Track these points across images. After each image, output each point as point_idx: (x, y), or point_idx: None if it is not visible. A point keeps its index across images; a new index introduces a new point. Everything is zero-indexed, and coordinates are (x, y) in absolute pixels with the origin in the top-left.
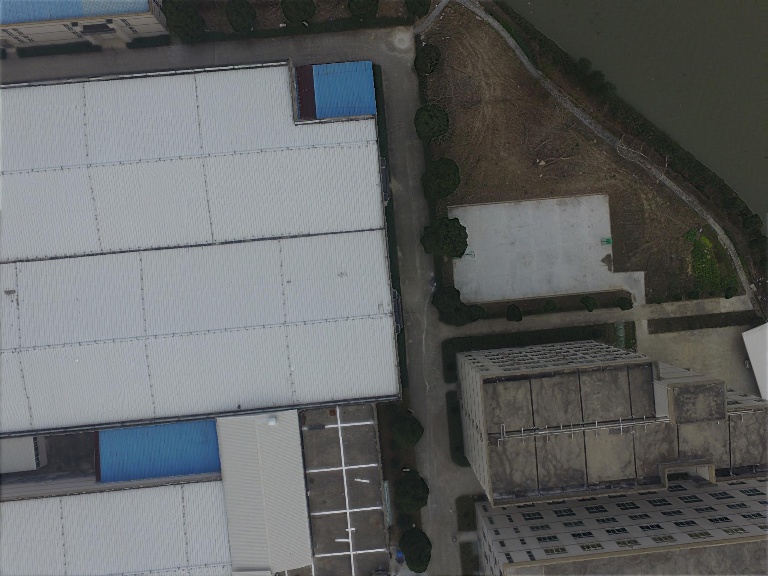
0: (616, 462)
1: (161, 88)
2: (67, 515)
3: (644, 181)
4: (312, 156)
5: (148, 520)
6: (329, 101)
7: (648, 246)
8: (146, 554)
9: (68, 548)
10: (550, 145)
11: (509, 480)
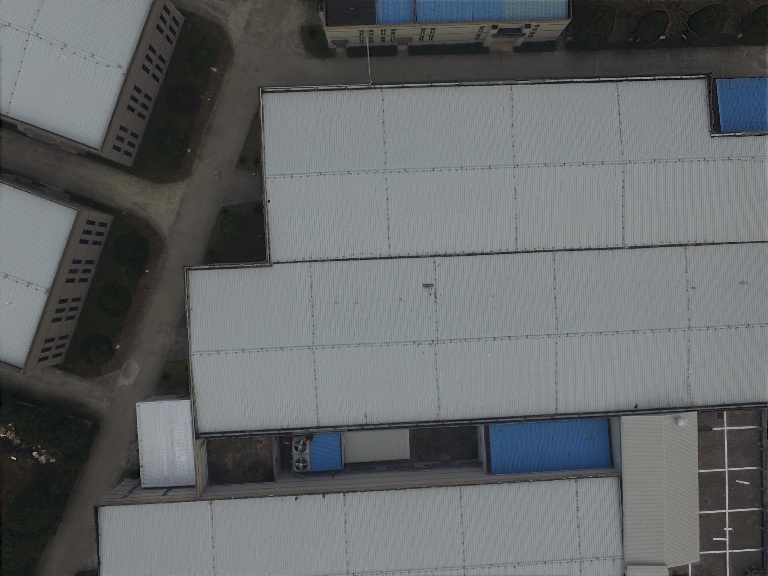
0: None
1: (585, 94)
2: (466, 504)
3: None
4: (726, 168)
5: (543, 512)
6: (732, 115)
7: None
8: (541, 545)
9: (467, 536)
10: None
11: None
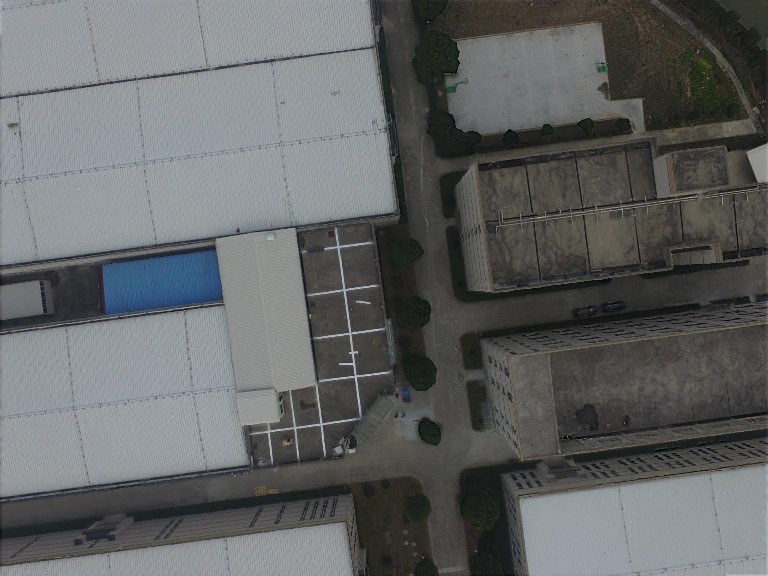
0: (619, 247)
1: None
2: (73, 344)
3: (637, 5)
4: None
5: (152, 346)
6: None
7: (644, 69)
8: (151, 380)
9: (75, 376)
10: None
11: (509, 269)
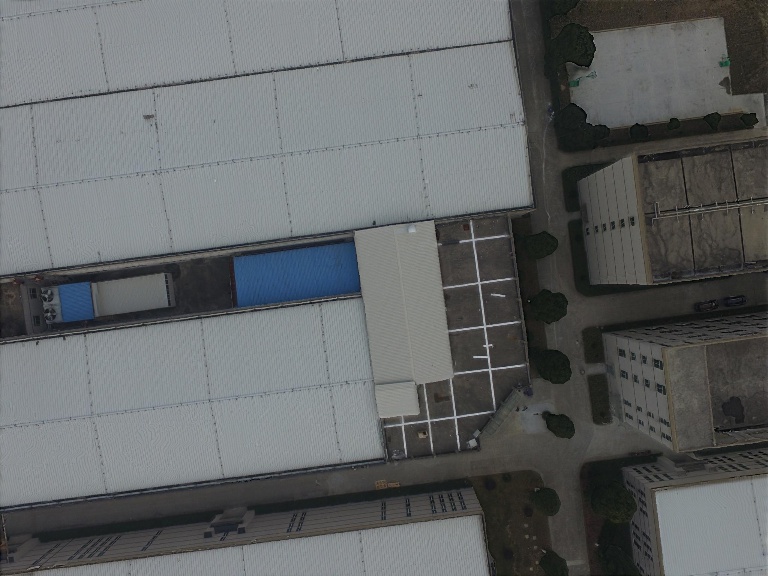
0: None
1: None
2: (208, 336)
3: None
4: None
5: (288, 339)
6: None
7: None
8: (287, 373)
9: (210, 369)
10: None
11: (664, 261)
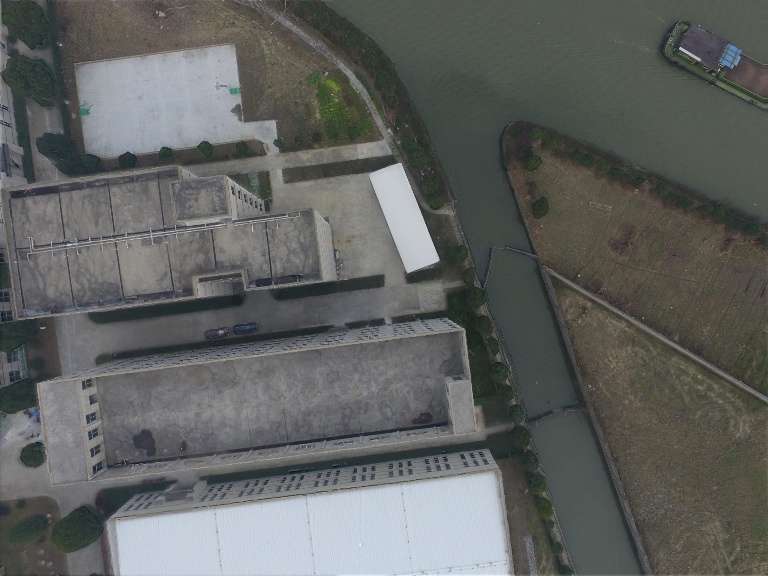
0: (152, 274)
1: None
2: None
3: (265, 27)
4: None
5: None
6: None
7: (271, 91)
8: None
9: None
10: None
11: (43, 295)
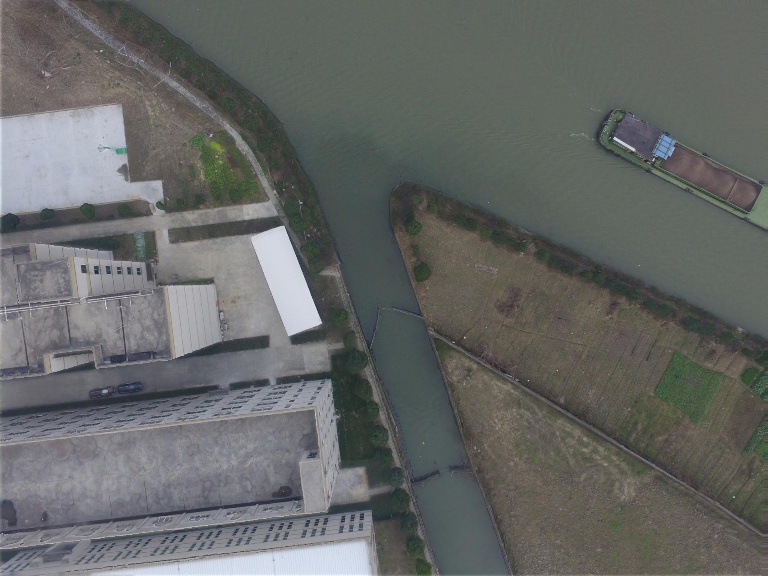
0: (7, 350)
1: None
2: None
3: (150, 88)
4: None
5: None
6: None
7: (155, 153)
8: None
9: None
10: (55, 56)
11: None
